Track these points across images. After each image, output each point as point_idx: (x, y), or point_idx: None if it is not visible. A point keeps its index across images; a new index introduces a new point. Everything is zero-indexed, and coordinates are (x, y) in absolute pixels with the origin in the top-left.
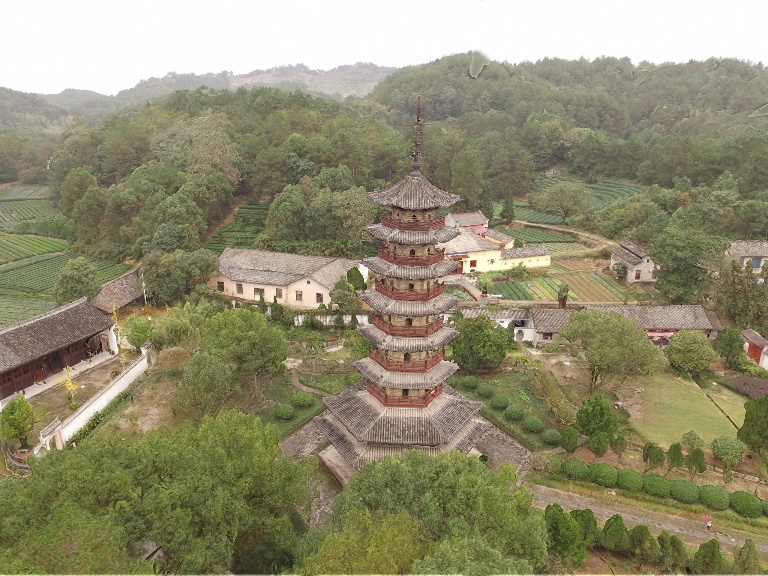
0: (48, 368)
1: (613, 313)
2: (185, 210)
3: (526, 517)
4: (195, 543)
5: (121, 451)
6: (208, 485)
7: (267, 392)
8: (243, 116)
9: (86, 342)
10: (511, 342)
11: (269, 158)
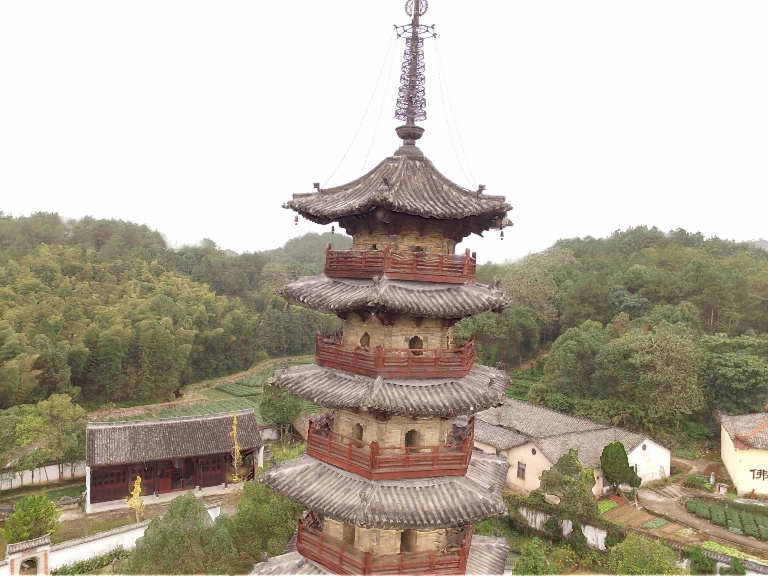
0: (189, 482)
1: None
2: None
3: None
4: None
5: None
6: None
7: None
8: (595, 254)
9: (225, 460)
10: None
11: (582, 290)
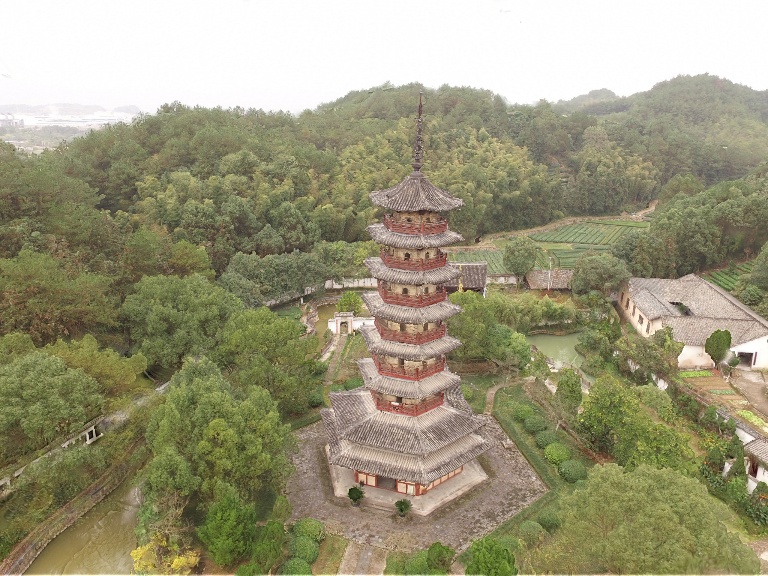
0: None
1: (695, 503)
2: (679, 224)
3: (274, 517)
4: (158, 340)
5: (187, 286)
6: (193, 325)
7: (470, 377)
8: None
9: None
10: (759, 518)
11: None
